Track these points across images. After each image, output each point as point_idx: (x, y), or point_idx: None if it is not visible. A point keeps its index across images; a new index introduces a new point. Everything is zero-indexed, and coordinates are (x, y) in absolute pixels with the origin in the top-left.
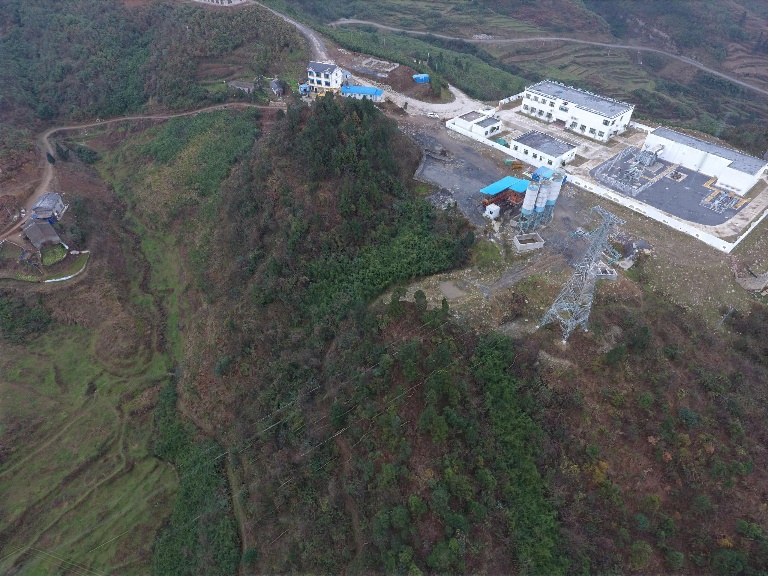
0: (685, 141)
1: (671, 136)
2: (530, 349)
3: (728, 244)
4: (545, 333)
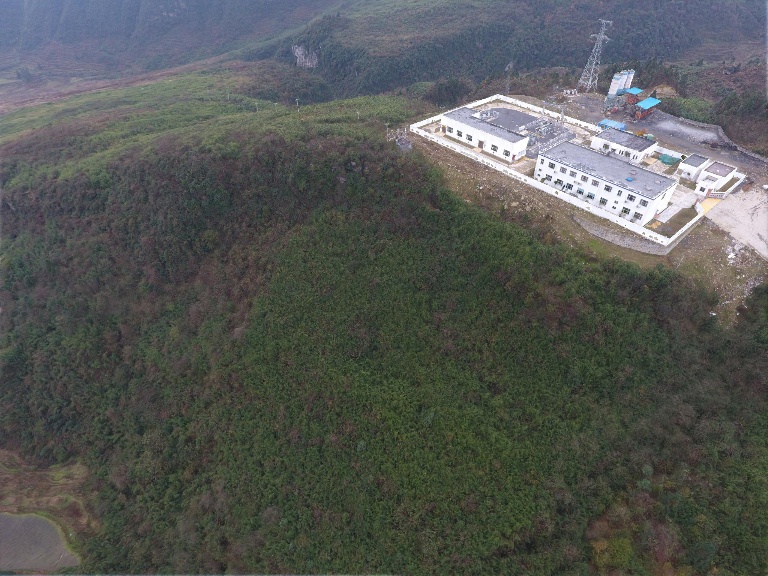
0: (497, 132)
1: (507, 136)
2: (600, 84)
3: (500, 95)
4: (593, 91)
